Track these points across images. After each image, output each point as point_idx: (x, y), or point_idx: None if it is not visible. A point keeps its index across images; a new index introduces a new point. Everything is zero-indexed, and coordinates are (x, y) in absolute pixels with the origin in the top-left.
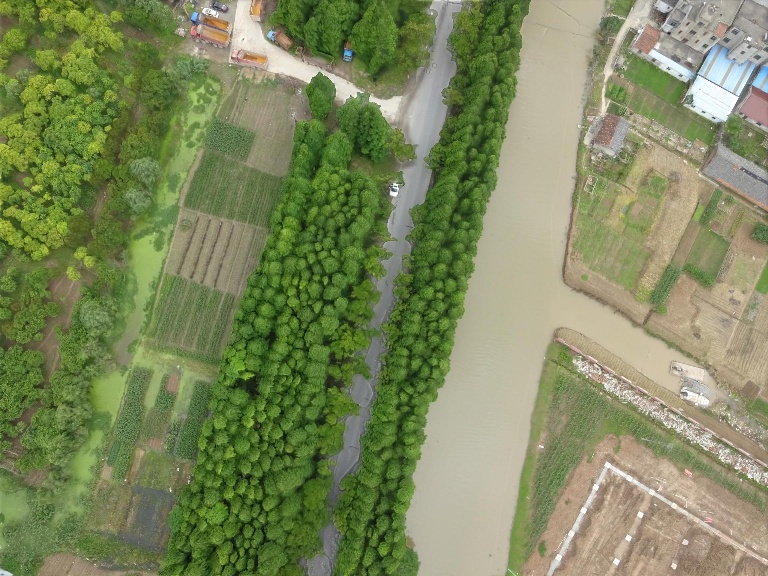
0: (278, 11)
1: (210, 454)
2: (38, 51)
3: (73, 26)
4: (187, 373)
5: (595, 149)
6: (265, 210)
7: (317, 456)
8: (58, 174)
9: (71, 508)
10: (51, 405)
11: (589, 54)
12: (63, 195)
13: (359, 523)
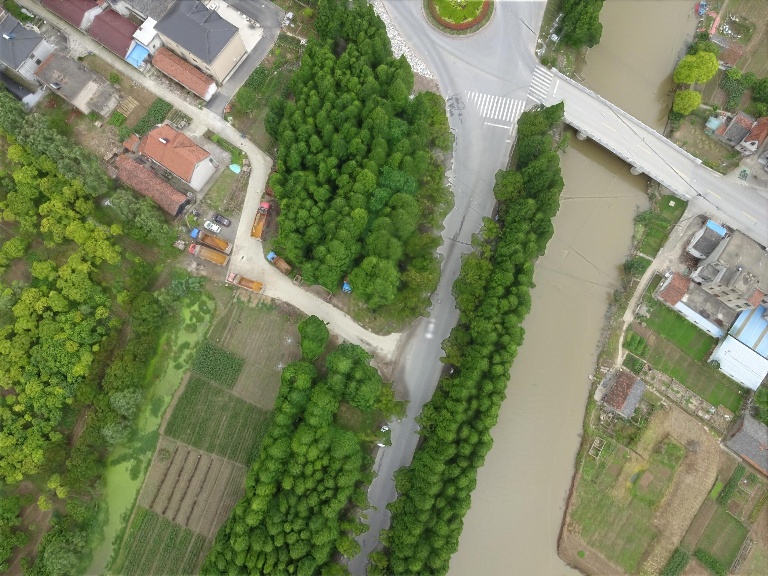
0: (279, 238)
1: None
2: (35, 263)
3: (72, 238)
4: None
5: (606, 407)
6: (246, 446)
7: None
8: (40, 396)
9: None
10: None
11: (610, 290)
12: (44, 416)
13: None
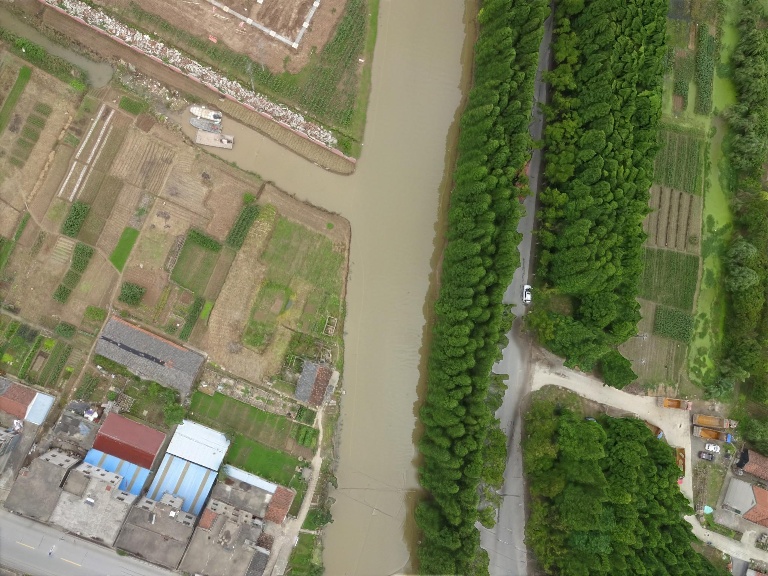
0: None
1: None
2: None
3: None
4: (669, 112)
5: None
6: None
7: None
8: None
9: (731, 4)
10: (766, 77)
11: None
12: None
13: None
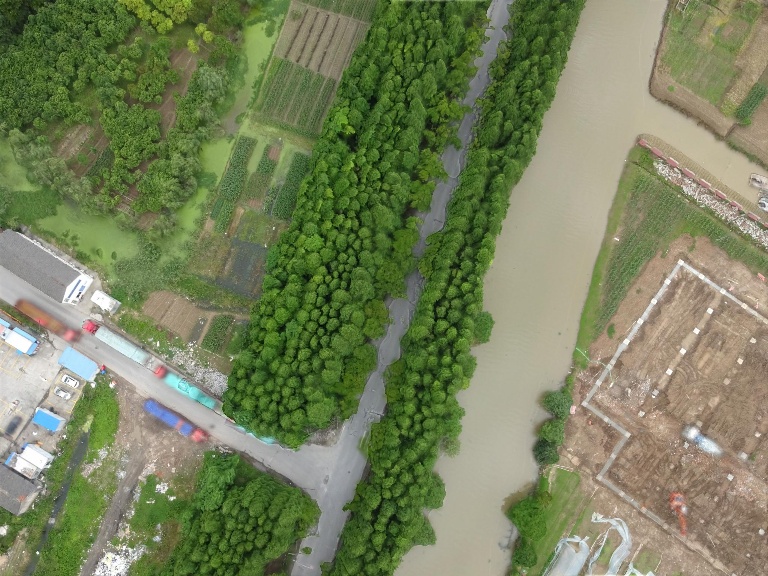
0: None
1: (310, 196)
2: None
3: None
4: (288, 145)
5: None
6: (369, 6)
7: (406, 214)
8: None
9: (176, 253)
10: (166, 157)
11: None
12: None
13: (445, 260)
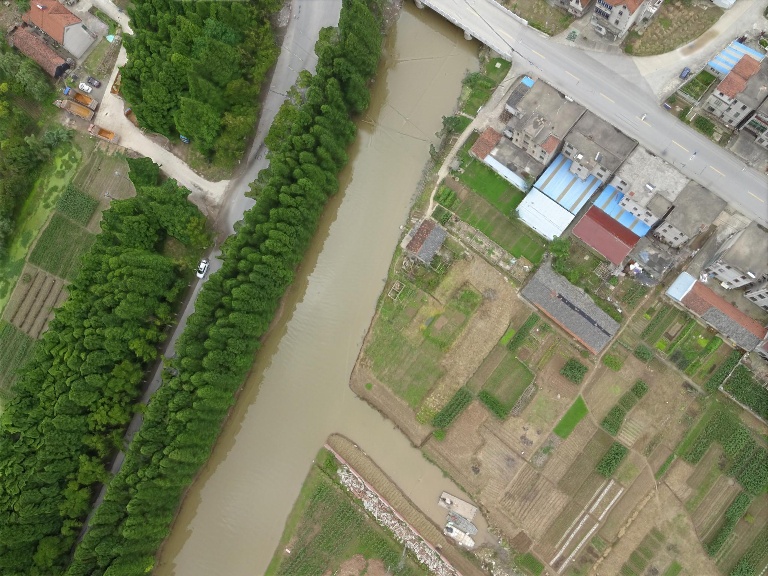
0: None
1: None
2: None
3: None
4: None
5: (410, 254)
6: None
7: None
8: None
9: None
10: None
11: (436, 151)
12: None
13: None
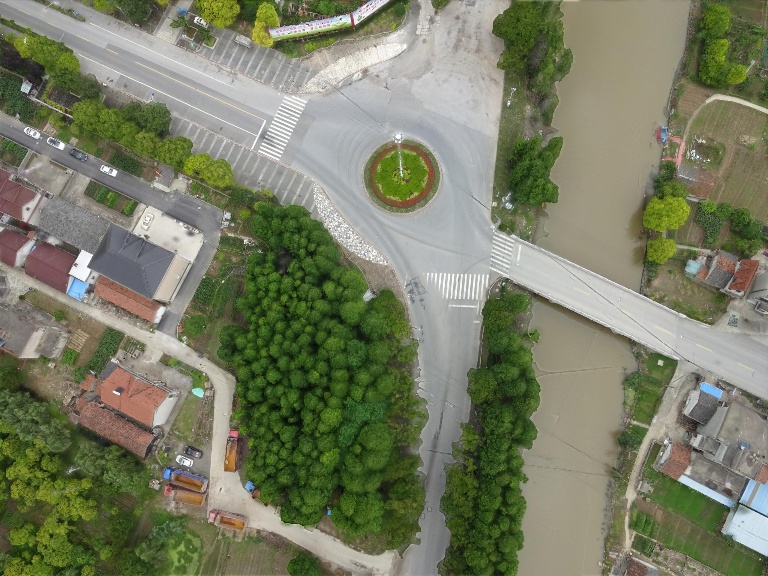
0: None
1: None
2: (11, 533)
3: (44, 500)
4: None
5: None
6: None
7: None
8: None
9: None
10: None
11: (608, 460)
12: None
13: None
